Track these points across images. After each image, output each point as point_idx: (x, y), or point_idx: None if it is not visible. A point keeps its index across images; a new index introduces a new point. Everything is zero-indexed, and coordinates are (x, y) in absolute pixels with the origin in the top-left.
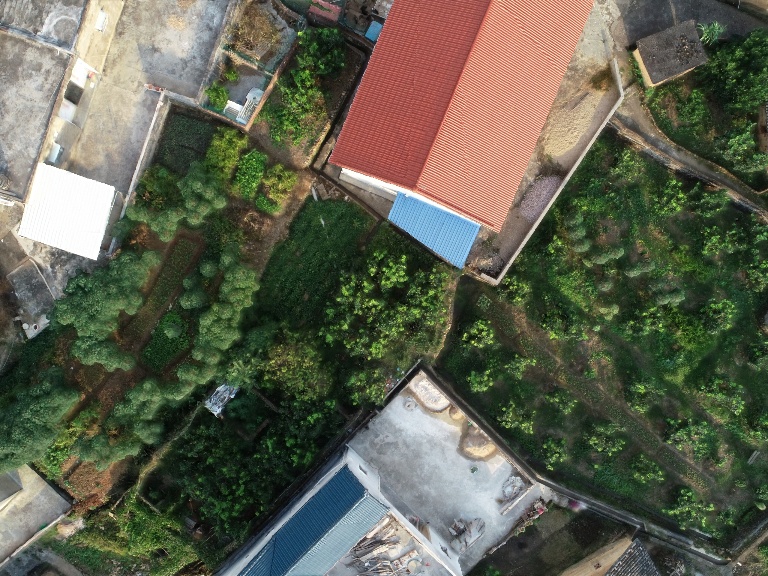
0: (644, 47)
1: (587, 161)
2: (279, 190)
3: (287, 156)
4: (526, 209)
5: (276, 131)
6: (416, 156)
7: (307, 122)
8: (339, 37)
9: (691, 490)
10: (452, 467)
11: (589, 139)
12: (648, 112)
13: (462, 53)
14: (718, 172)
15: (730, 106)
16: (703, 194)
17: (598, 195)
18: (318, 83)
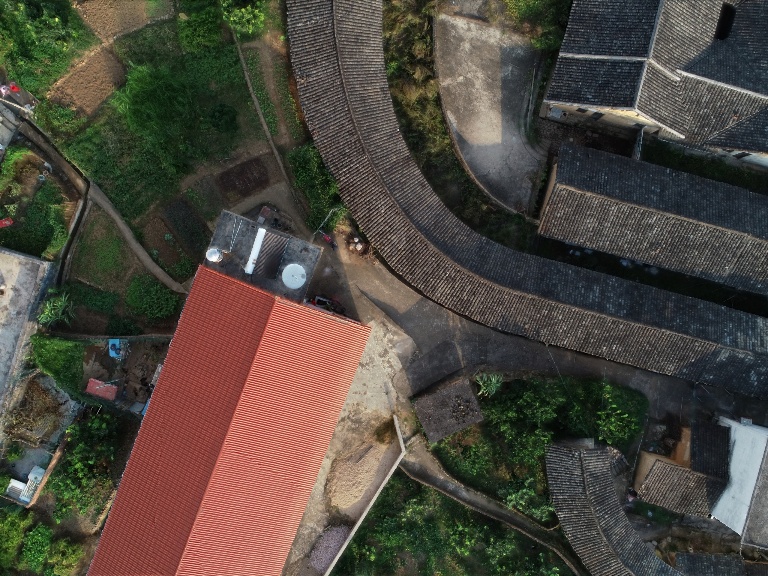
0: (420, 409)
1: (383, 496)
2: (64, 565)
3: (75, 525)
4: (316, 560)
5: (55, 514)
6: None
7: (93, 491)
8: (112, 423)
9: None
10: None
11: (373, 494)
12: (434, 459)
13: (195, 500)
14: (508, 510)
15: (510, 458)
16: (490, 538)
17: (394, 531)
18: (97, 462)
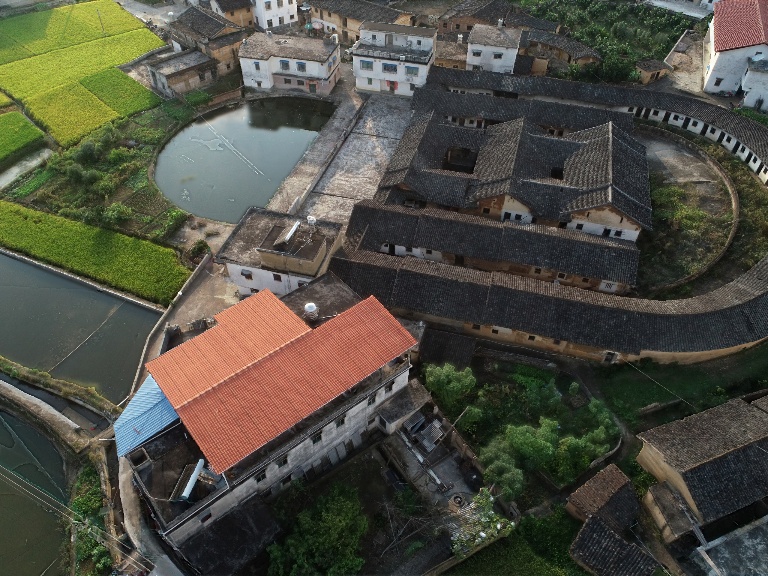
0: None
1: None
2: None
3: None
4: None
5: None
6: (761, 0)
7: None
8: None
9: (584, 4)
10: (674, 8)
11: None
12: None
13: None
14: None
15: None
16: None
17: None
18: None
